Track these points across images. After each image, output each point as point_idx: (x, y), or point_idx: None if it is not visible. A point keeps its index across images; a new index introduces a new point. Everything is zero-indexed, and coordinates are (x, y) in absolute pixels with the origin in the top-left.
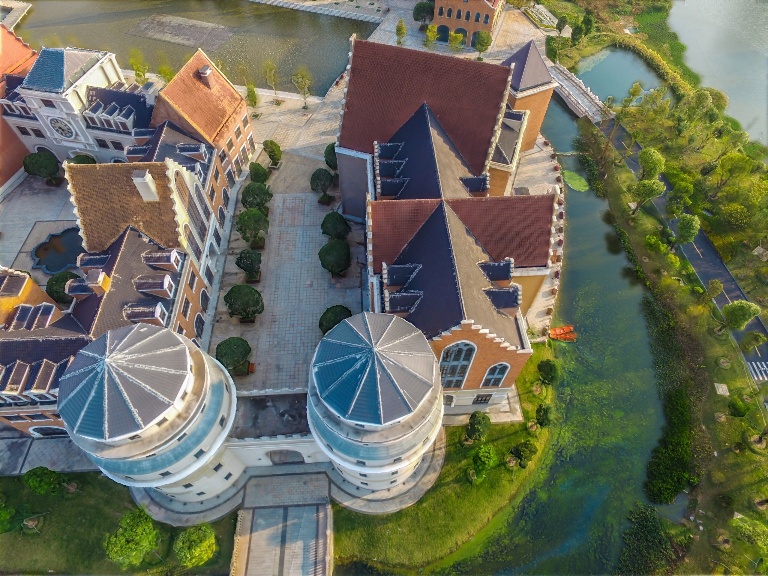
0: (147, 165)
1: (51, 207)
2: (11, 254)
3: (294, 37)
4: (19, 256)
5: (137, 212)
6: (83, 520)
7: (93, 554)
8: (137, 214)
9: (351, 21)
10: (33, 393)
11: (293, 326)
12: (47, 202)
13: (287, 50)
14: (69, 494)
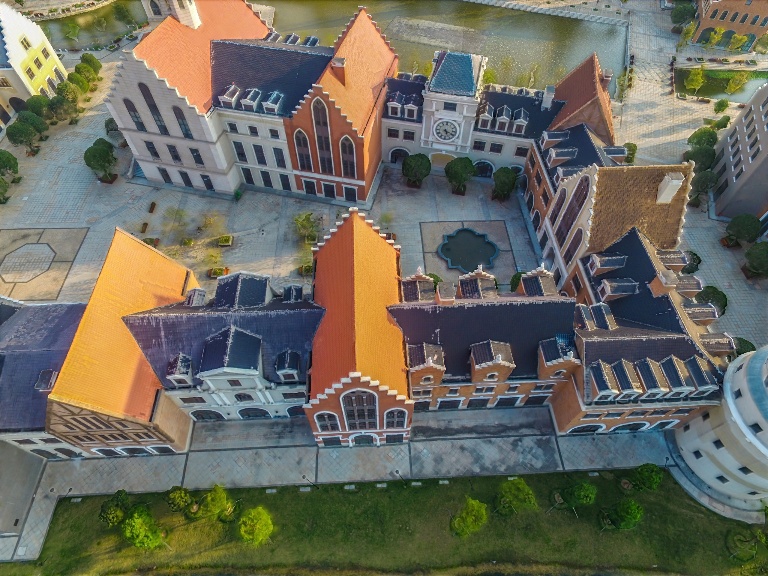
0: (672, 168)
1: (425, 208)
2: (417, 254)
3: (549, 40)
4: (426, 256)
5: (646, 214)
6: (653, 516)
7: (680, 550)
8: (645, 216)
9: (595, 24)
10: (661, 391)
11: (739, 327)
12: (418, 203)
13: (550, 53)
14: (628, 491)
